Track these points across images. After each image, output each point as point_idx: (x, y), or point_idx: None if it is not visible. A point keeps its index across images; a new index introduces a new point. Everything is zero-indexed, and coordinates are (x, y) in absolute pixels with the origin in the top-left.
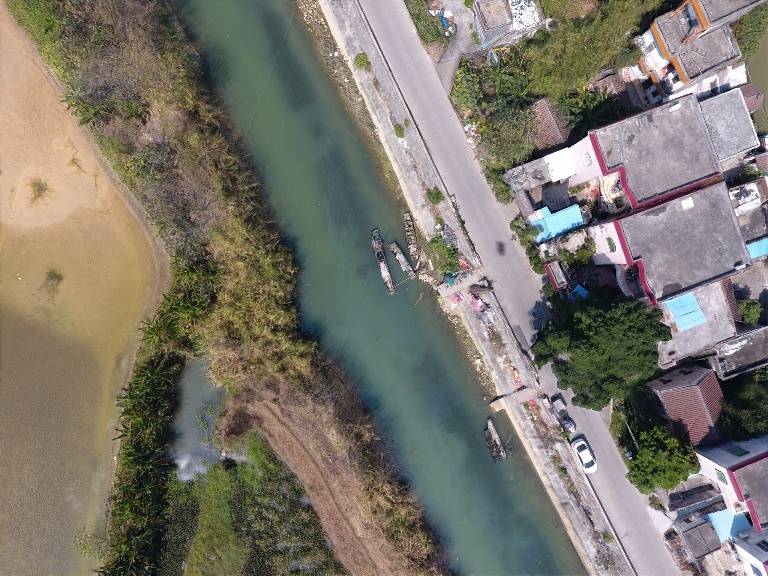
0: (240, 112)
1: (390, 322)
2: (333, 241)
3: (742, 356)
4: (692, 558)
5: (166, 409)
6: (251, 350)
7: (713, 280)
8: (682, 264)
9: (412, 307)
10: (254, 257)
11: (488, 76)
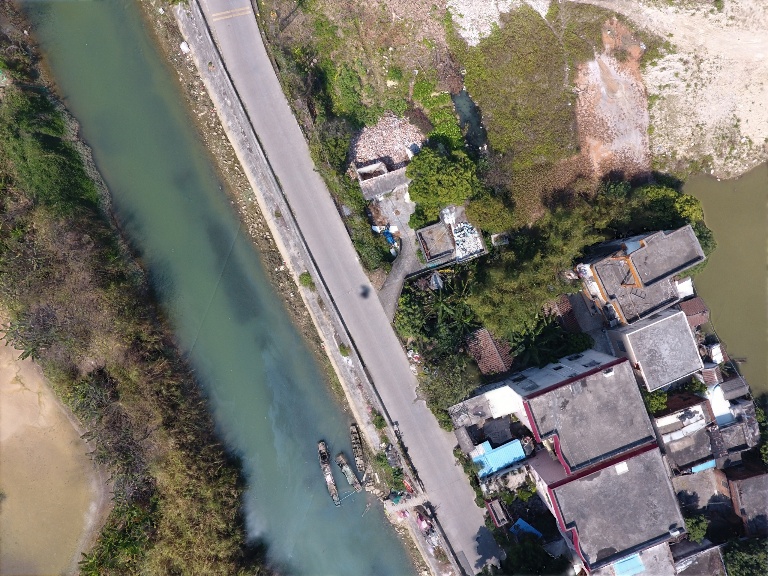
0: (185, 327)
1: (337, 534)
2: (279, 454)
3: (687, 575)
4: None
5: None
6: None
7: (647, 546)
8: (616, 528)
9: (359, 519)
10: (194, 491)
11: (431, 304)
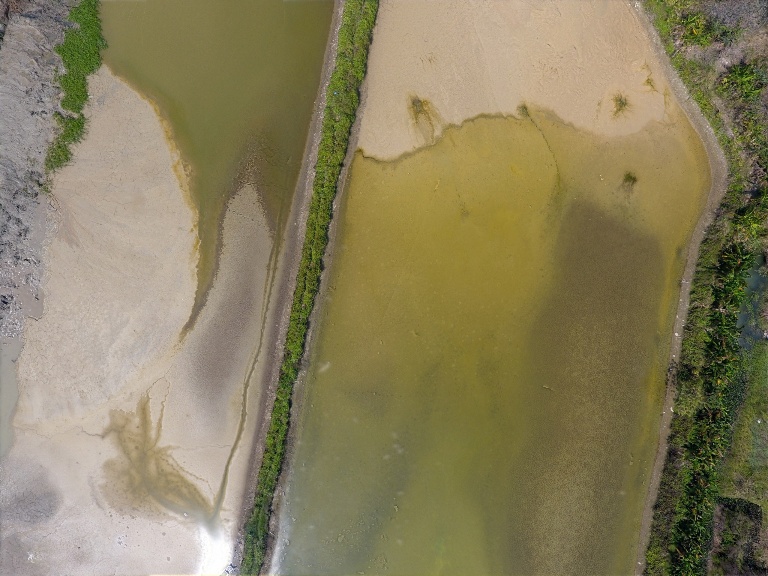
0: None
1: None
2: None
3: None
4: None
5: None
6: None
7: None
8: None
9: None
10: None
11: None
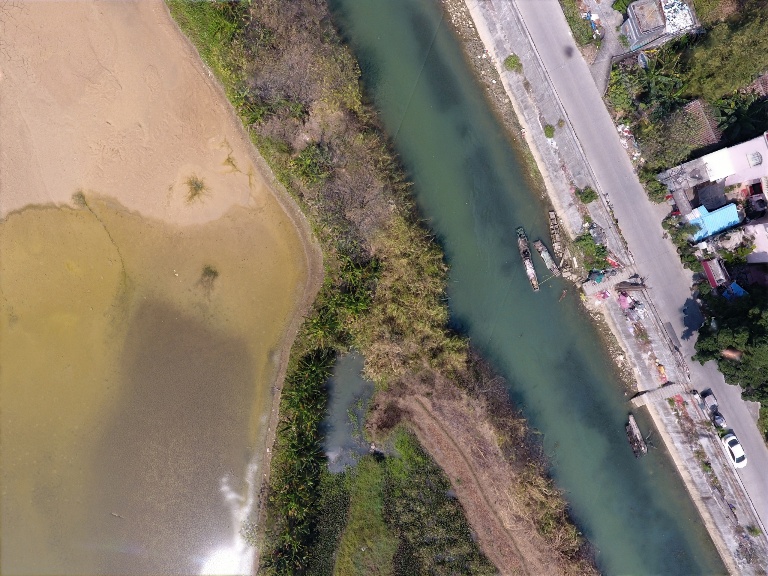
0: (390, 113)
1: (534, 319)
2: (479, 239)
3: None
4: None
5: (324, 402)
6: (409, 345)
7: None
8: None
9: (556, 304)
10: (415, 254)
11: (642, 78)
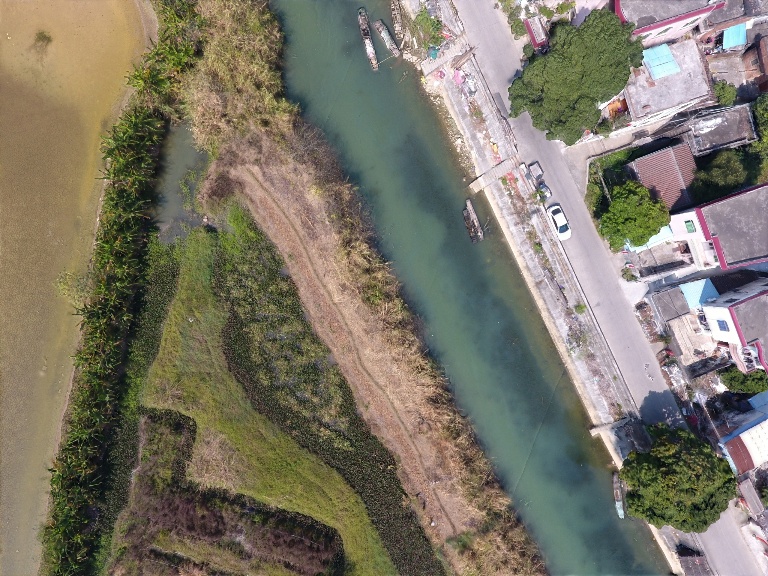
0: None
1: (373, 100)
2: (320, 17)
3: (717, 135)
4: (661, 325)
5: (149, 163)
6: (235, 105)
7: None
8: None
9: (395, 86)
10: (240, 9)
11: None
